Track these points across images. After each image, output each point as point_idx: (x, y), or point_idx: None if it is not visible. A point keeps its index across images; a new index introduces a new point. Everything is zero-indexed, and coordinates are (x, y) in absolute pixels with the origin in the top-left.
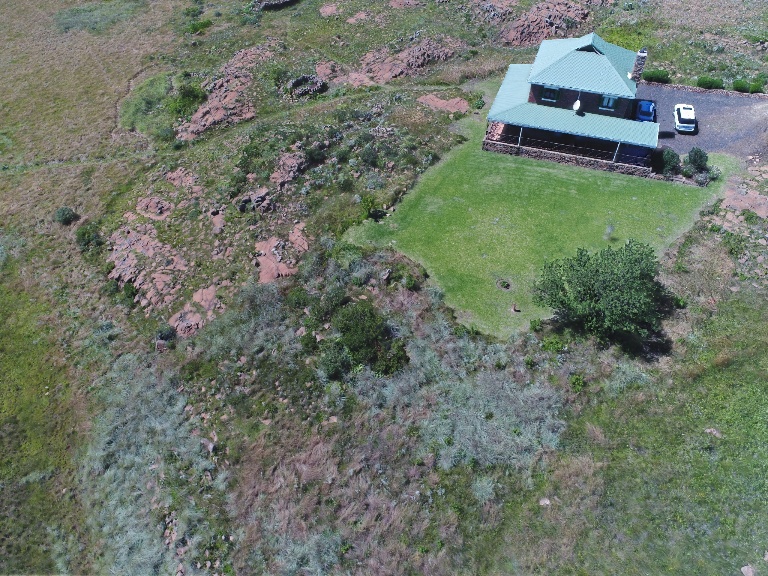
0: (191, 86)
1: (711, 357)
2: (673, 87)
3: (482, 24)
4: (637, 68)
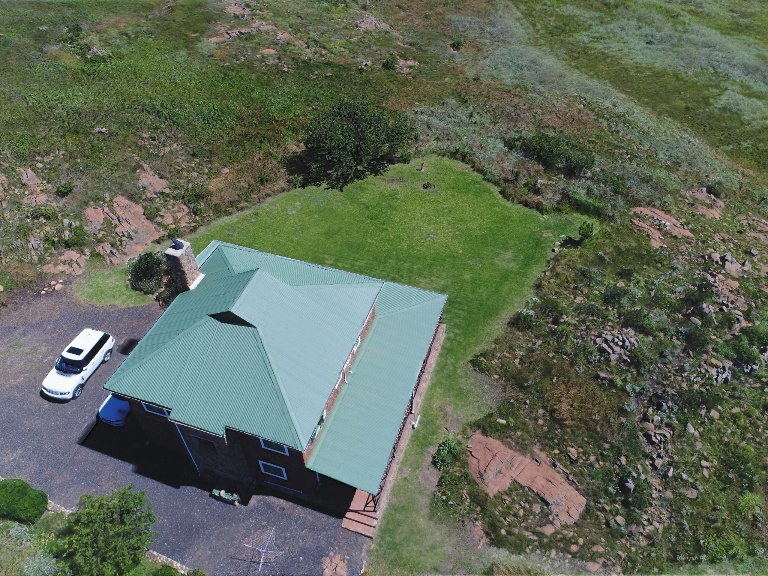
0: None
1: None
2: None
3: None
4: None
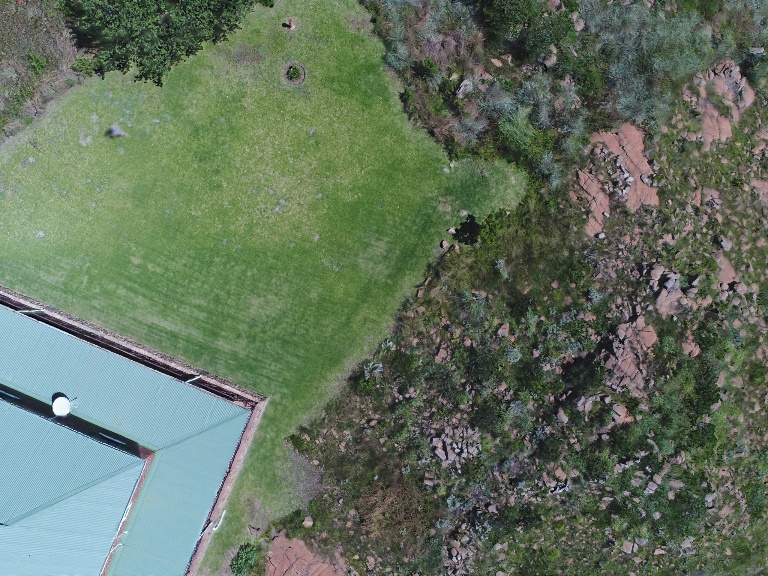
0: None
1: None
2: None
3: None
4: None
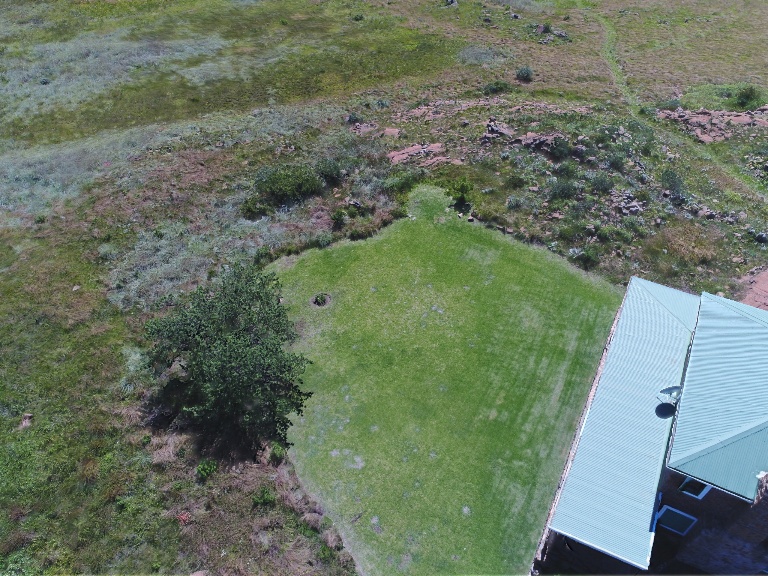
0: None
1: None
2: None
3: None
4: None
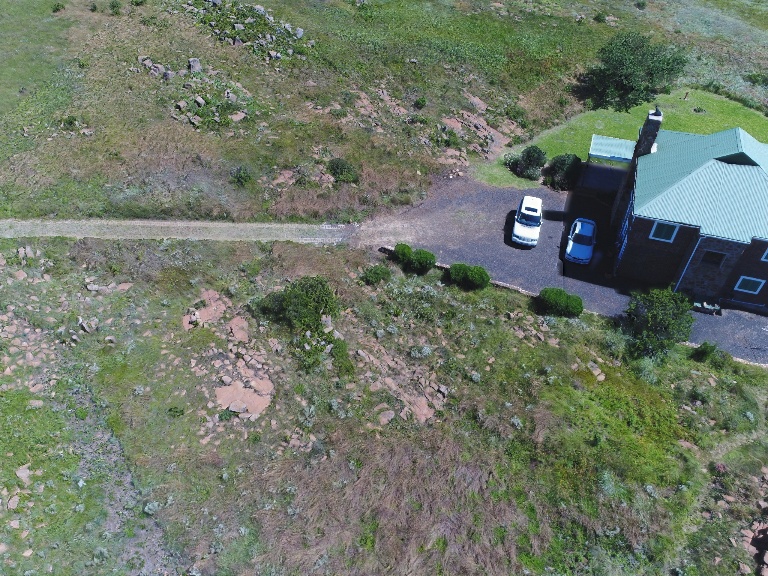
0: None
1: None
2: None
3: None
4: None
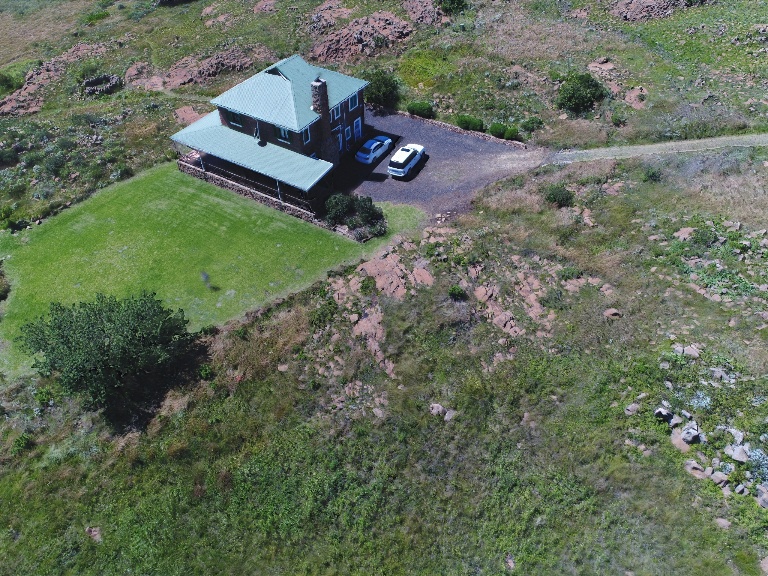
0: (11, 76)
1: (171, 443)
2: (434, 123)
3: (302, 35)
4: (315, 98)
